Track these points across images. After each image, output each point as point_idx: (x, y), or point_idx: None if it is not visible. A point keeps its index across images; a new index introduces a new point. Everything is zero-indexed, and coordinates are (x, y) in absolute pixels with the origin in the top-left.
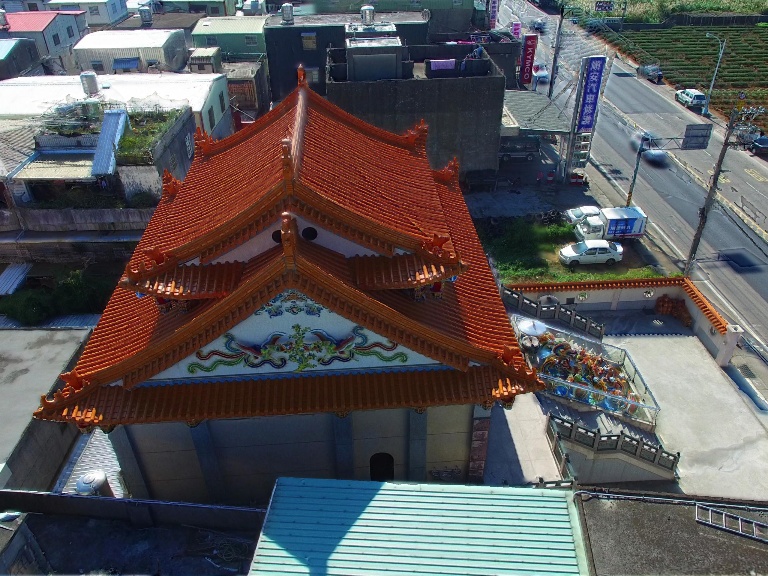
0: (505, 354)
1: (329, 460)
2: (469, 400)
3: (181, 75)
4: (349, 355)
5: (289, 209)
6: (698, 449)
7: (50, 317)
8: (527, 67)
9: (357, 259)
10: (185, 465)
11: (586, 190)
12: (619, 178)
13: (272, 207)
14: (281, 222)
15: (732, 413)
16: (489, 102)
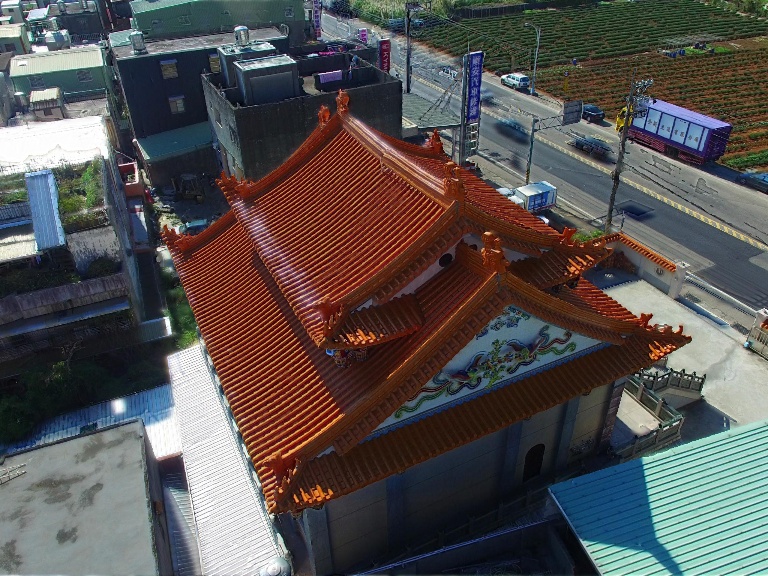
0: (644, 321)
1: (495, 467)
2: (636, 369)
3: (50, 123)
4: (533, 358)
5: (466, 230)
6: (701, 369)
7: (35, 425)
8: (385, 70)
9: (509, 266)
10: (369, 520)
11: (481, 175)
12: (501, 160)
13: (444, 232)
14: (453, 245)
15: (705, 334)
16: (390, 107)
